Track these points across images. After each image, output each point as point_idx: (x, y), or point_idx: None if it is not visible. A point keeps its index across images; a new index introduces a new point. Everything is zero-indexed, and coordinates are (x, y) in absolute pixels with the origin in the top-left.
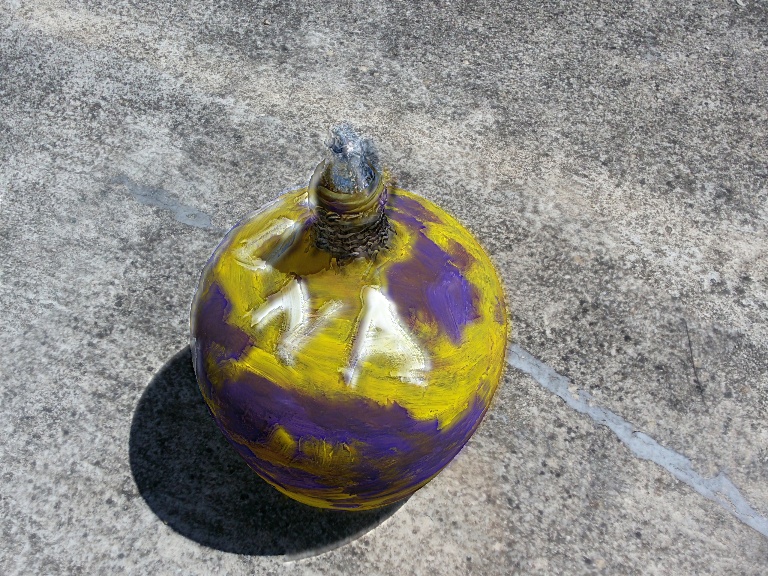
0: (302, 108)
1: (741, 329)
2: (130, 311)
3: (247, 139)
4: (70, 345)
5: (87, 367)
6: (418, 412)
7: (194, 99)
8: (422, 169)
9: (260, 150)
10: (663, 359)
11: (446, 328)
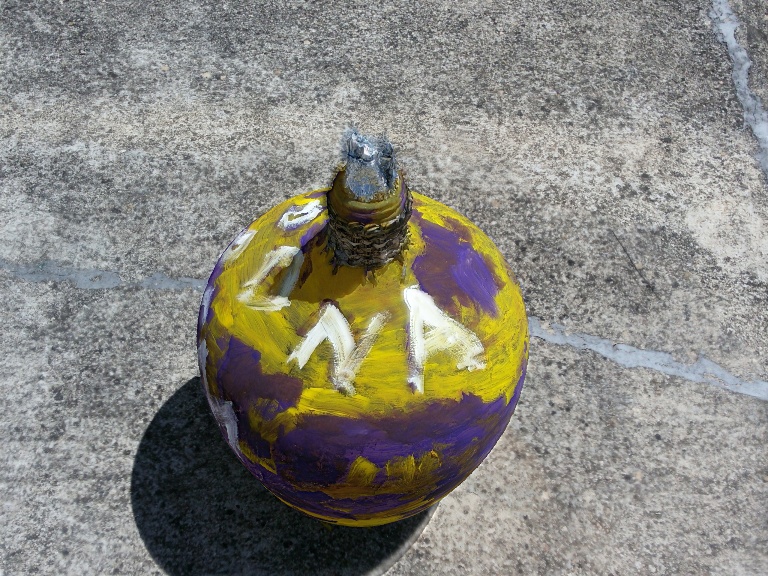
0: (162, 132)
1: (659, 222)
2: (75, 400)
3: (118, 180)
4: (24, 459)
5: (55, 476)
6: (490, 395)
7: (40, 154)
8: (313, 160)
9: (138, 188)
10: (608, 271)
11: (487, 305)
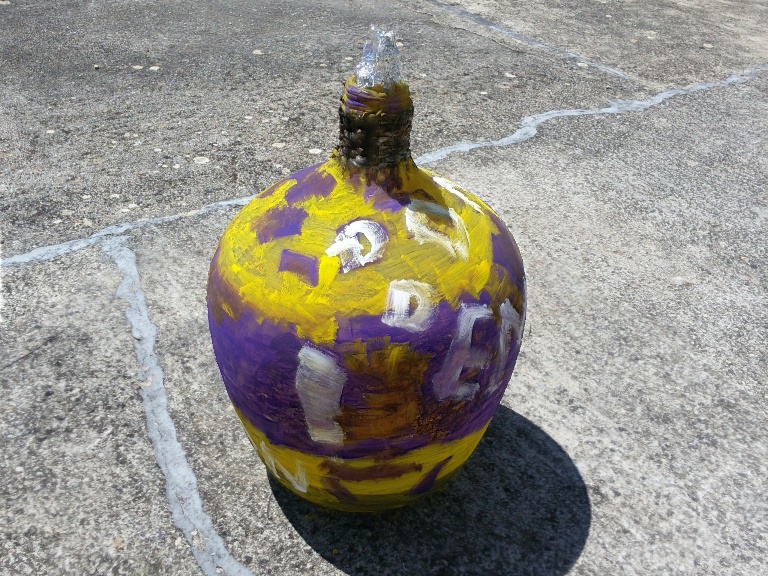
0: None
1: None
2: None
3: None
4: None
5: None
6: None
7: None
8: None
9: None
10: (45, 368)
11: None
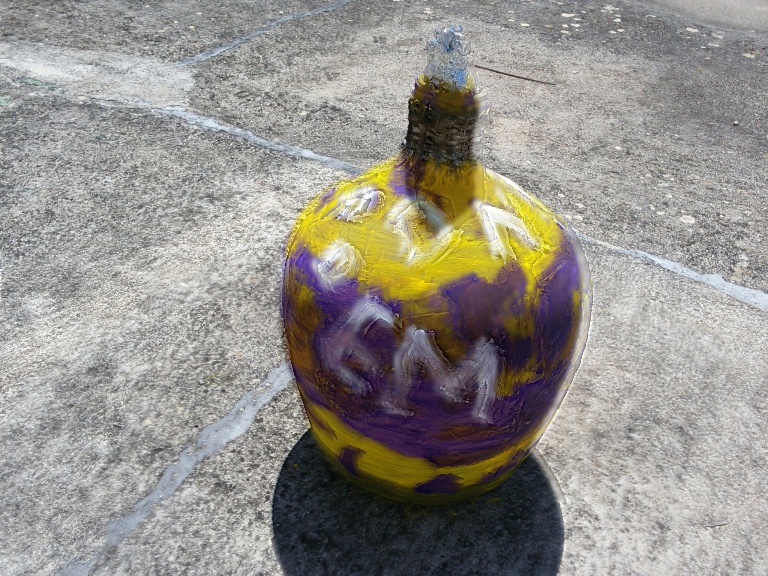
0: None
1: None
2: None
3: None
4: None
5: None
6: None
7: None
8: (88, 358)
9: None
10: None
11: None
